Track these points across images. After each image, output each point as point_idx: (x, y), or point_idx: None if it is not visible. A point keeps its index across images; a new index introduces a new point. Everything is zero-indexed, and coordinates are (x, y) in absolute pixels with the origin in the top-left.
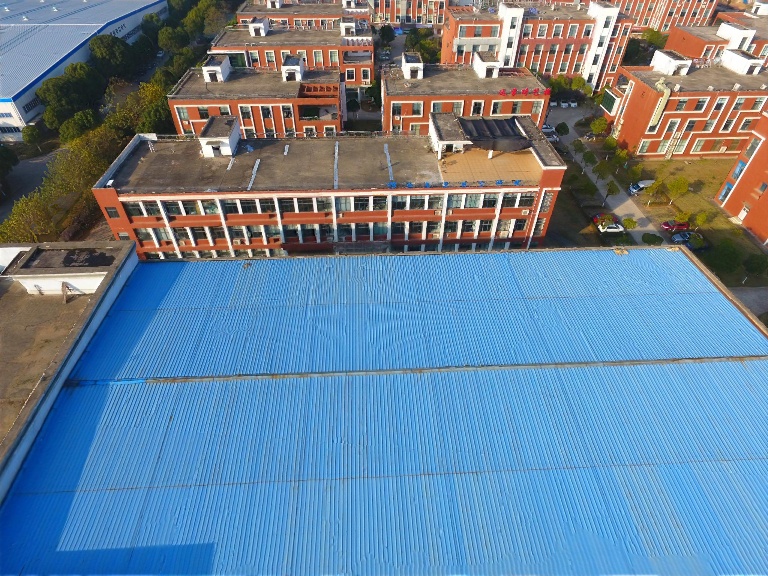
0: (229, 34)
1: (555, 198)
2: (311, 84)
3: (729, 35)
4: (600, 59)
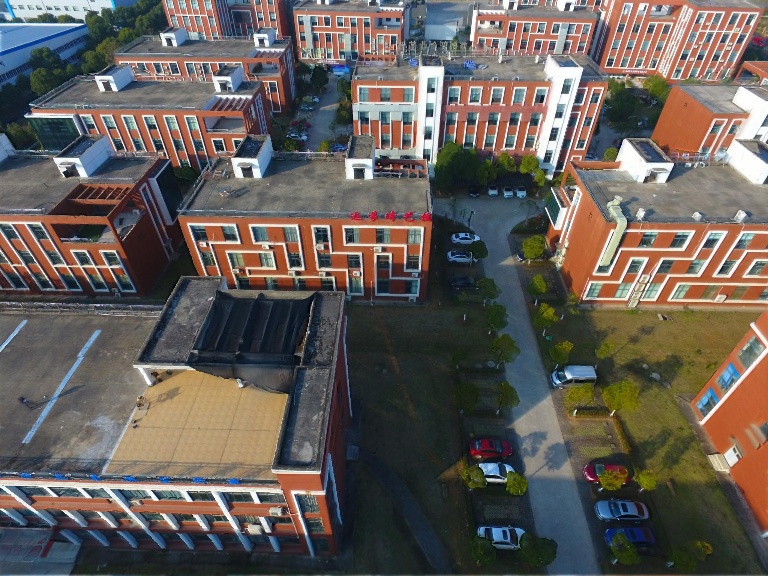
0: (77, 87)
1: (323, 500)
2: (95, 184)
3: (749, 105)
4: (560, 133)
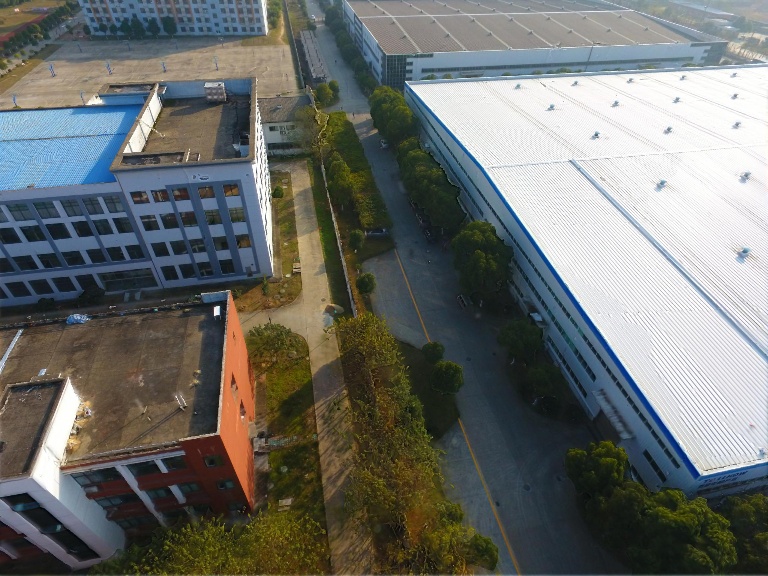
0: None
1: None
2: None
3: None
4: None
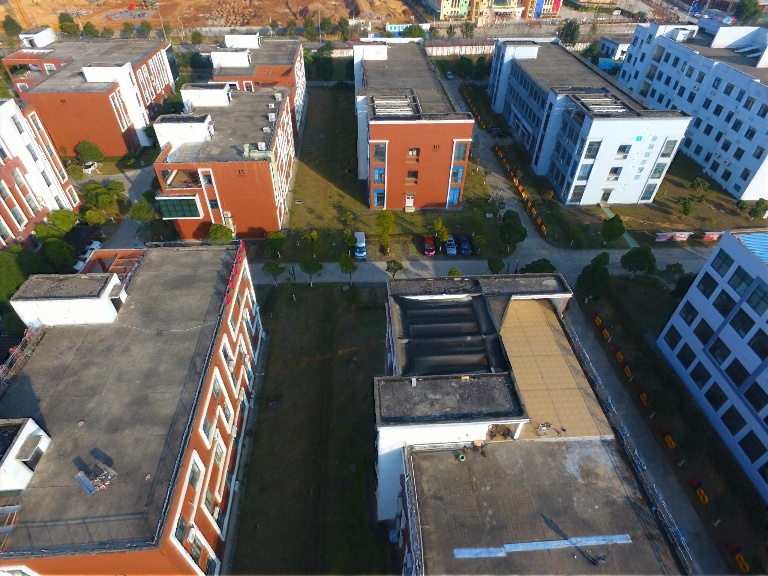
0: None
1: None
2: None
3: (111, 76)
4: (49, 175)
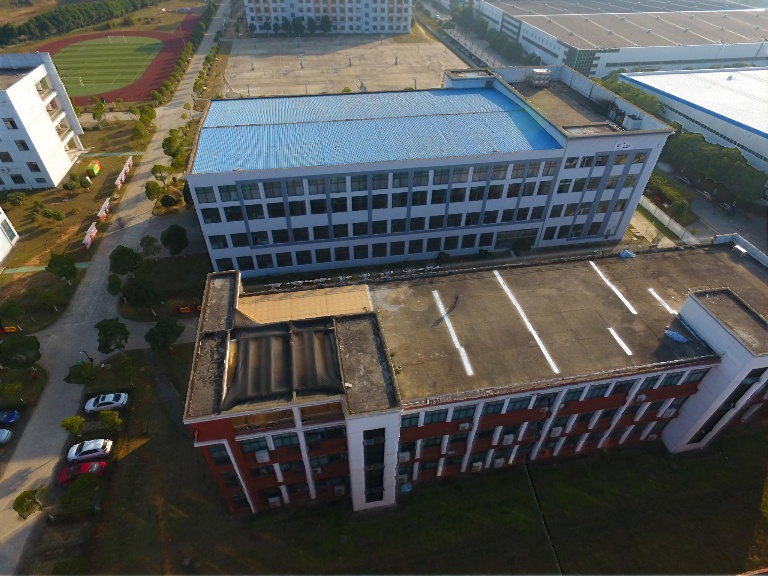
0: None
1: None
2: None
3: None
4: None
